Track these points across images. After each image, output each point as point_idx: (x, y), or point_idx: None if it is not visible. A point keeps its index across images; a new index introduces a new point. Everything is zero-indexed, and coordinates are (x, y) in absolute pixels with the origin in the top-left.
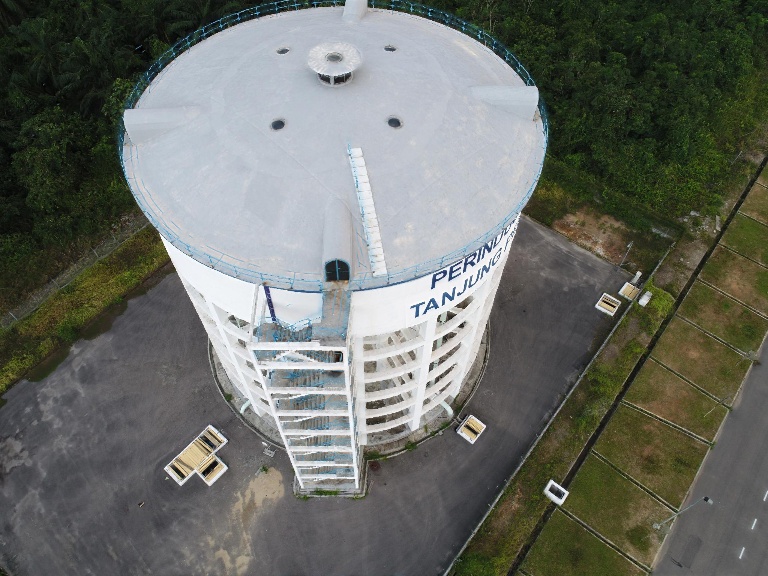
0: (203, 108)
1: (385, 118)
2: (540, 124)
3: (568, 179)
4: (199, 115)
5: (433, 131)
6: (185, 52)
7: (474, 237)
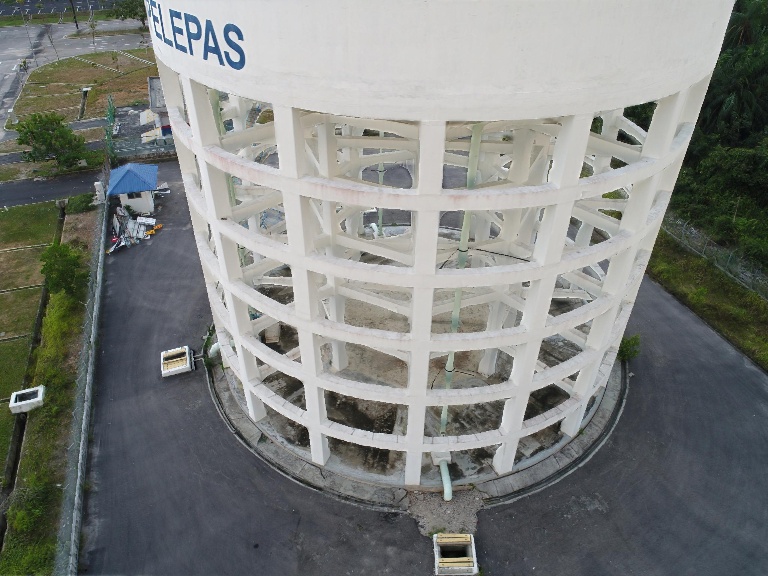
0: None
1: None
2: None
3: None
4: None
5: None
6: None
7: None
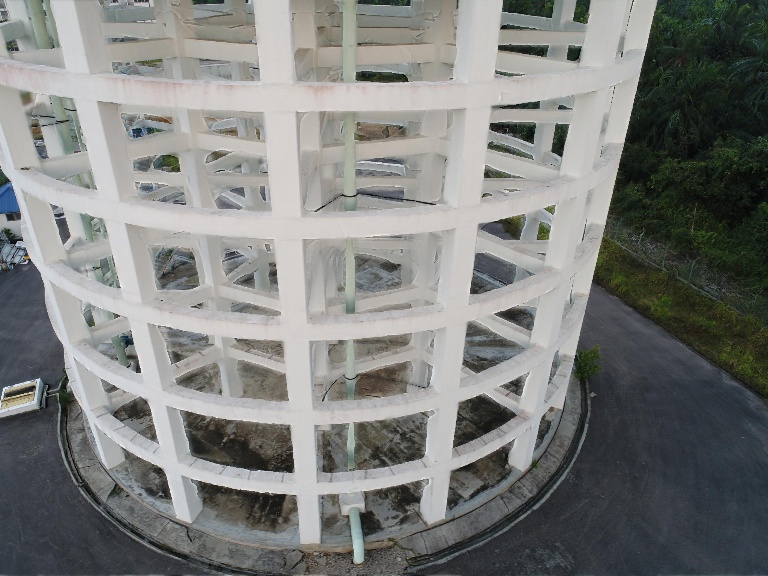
0: None
1: None
2: None
3: None
4: None
5: None
6: None
7: None
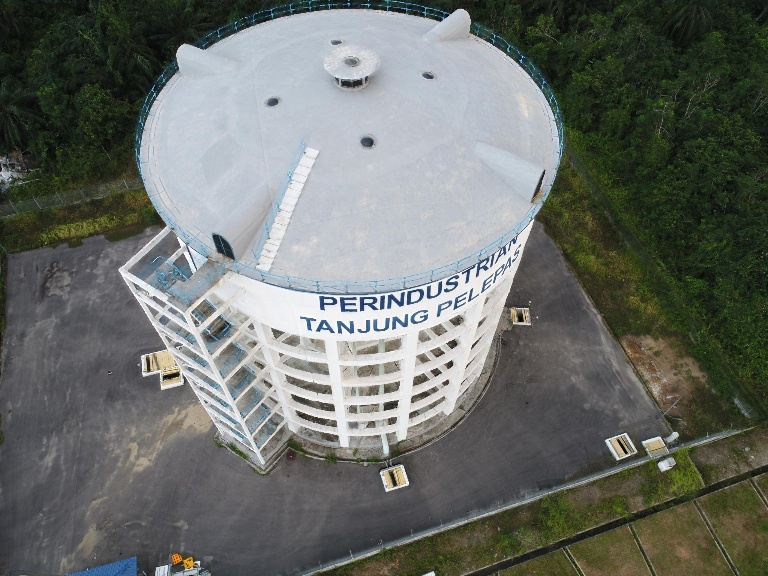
0: (240, 65)
1: (362, 134)
2: (536, 209)
3: (671, 300)
4: (232, 70)
5: (399, 165)
6: (285, 17)
7: (371, 280)
